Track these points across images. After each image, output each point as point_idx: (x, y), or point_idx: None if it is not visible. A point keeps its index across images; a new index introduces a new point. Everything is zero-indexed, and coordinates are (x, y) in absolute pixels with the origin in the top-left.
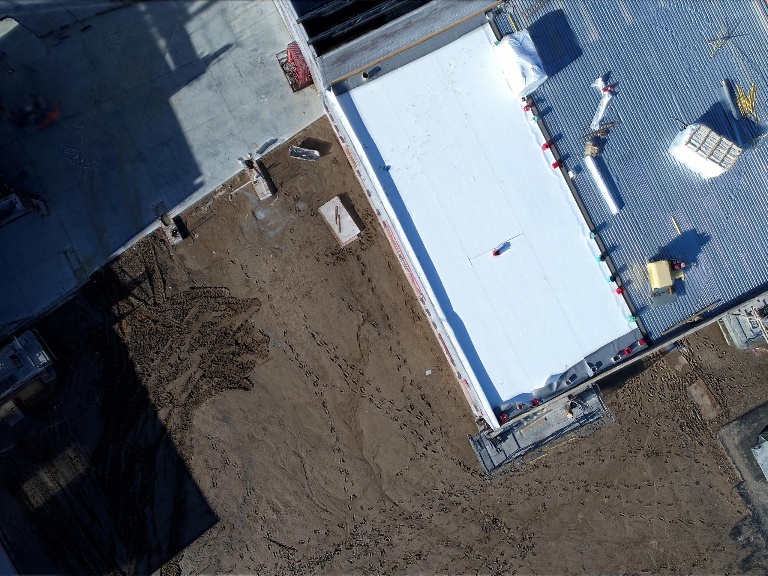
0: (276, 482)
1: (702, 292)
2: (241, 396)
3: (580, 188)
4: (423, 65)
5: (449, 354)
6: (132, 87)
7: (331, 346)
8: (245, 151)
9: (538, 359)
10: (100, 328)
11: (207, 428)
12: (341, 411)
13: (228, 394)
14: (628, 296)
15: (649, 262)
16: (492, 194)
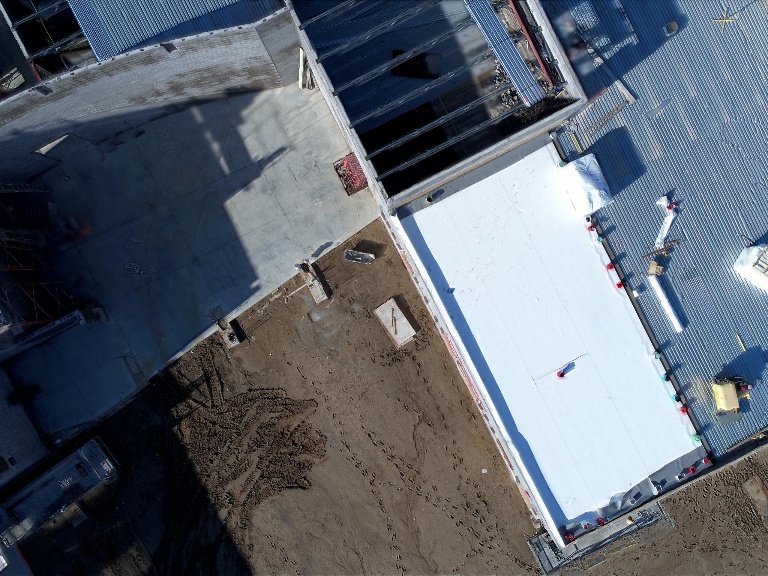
0: None
1: (767, 408)
2: (299, 495)
3: (644, 306)
4: (487, 186)
5: (507, 459)
6: (187, 192)
7: (387, 445)
8: (300, 255)
9: (602, 478)
10: (159, 430)
11: (266, 527)
12: (397, 509)
13: (286, 493)
14: (692, 414)
15: (715, 383)
16: (556, 315)
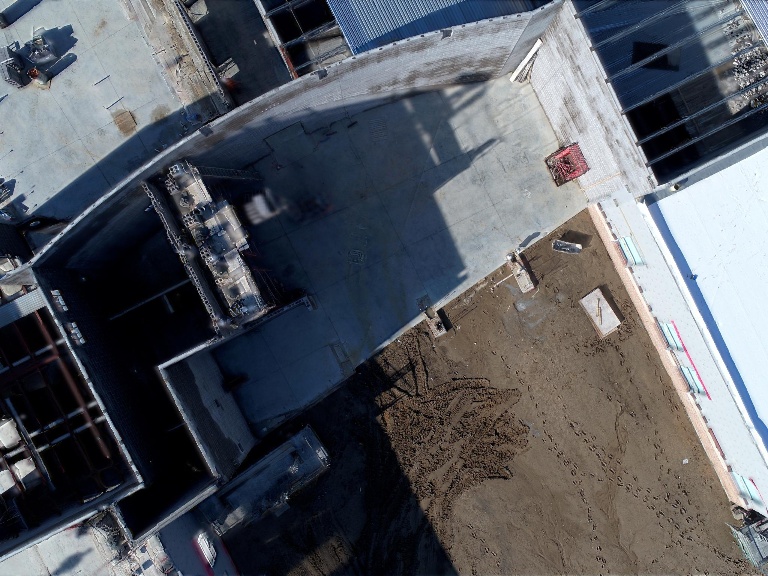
0: (534, 570)
1: None
2: (500, 485)
3: None
4: (729, 175)
5: (720, 448)
6: (398, 182)
7: (589, 436)
8: (508, 245)
9: None
10: (363, 419)
11: (467, 517)
12: (598, 500)
13: (488, 483)
14: None
15: None
16: None
